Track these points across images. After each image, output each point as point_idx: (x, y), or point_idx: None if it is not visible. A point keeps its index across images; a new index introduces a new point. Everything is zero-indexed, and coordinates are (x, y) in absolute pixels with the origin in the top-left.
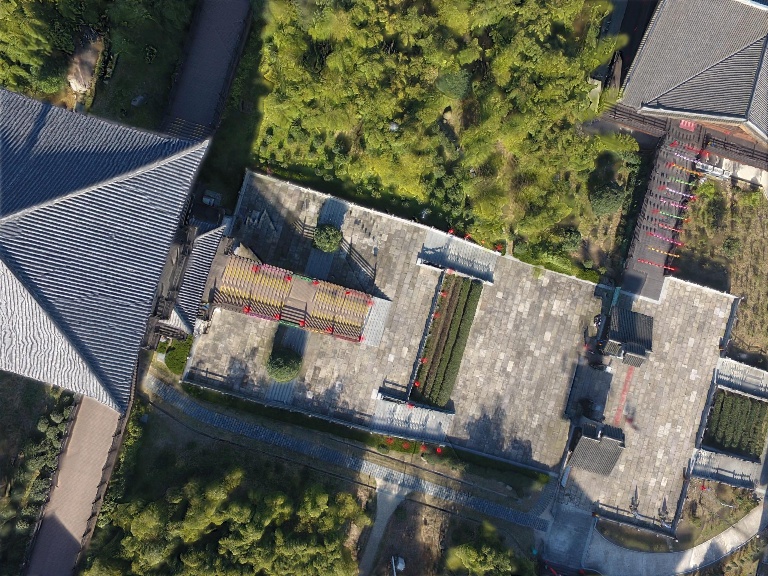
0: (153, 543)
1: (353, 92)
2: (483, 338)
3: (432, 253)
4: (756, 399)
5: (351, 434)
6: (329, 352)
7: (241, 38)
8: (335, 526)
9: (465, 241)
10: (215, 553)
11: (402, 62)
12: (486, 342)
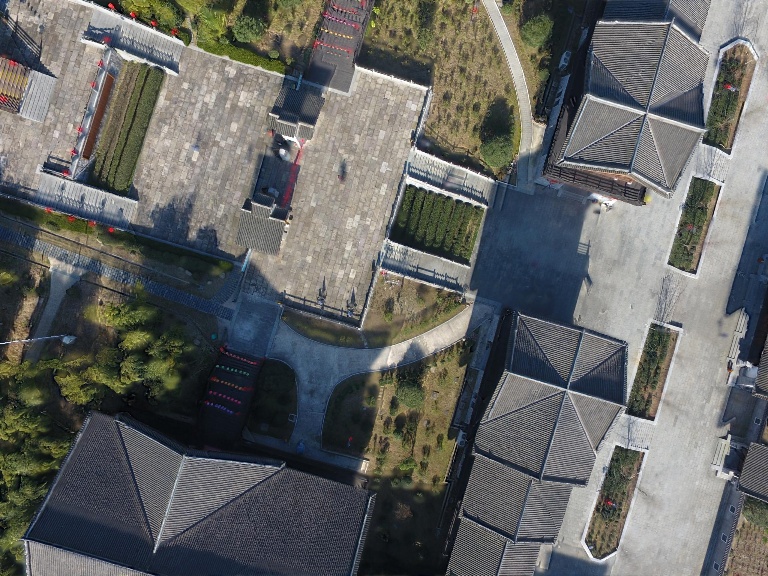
0: None
1: None
2: (168, 128)
3: (100, 33)
4: (462, 201)
5: (18, 209)
6: None
7: None
8: None
9: (138, 24)
10: None
11: None
12: (171, 132)
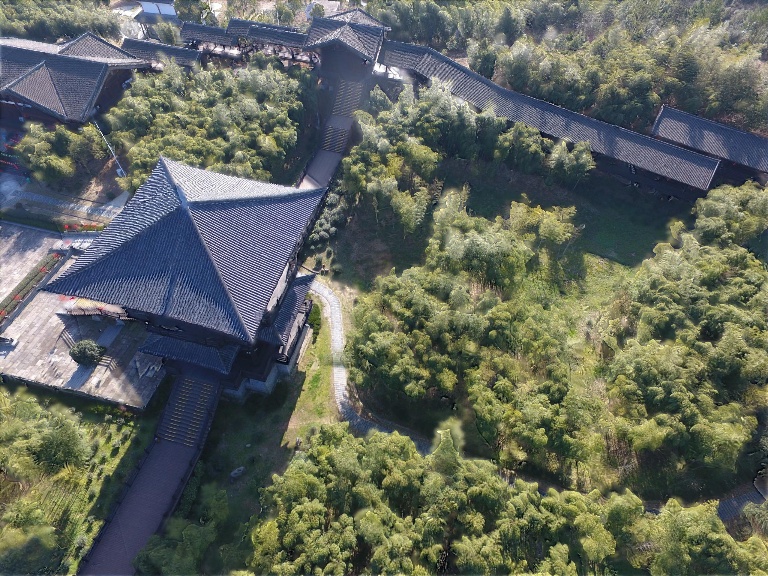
0: (240, 160)
1: None
2: None
3: (1, 353)
4: None
5: None
6: None
7: (98, 541)
8: None
9: None
10: (207, 158)
11: None
12: None
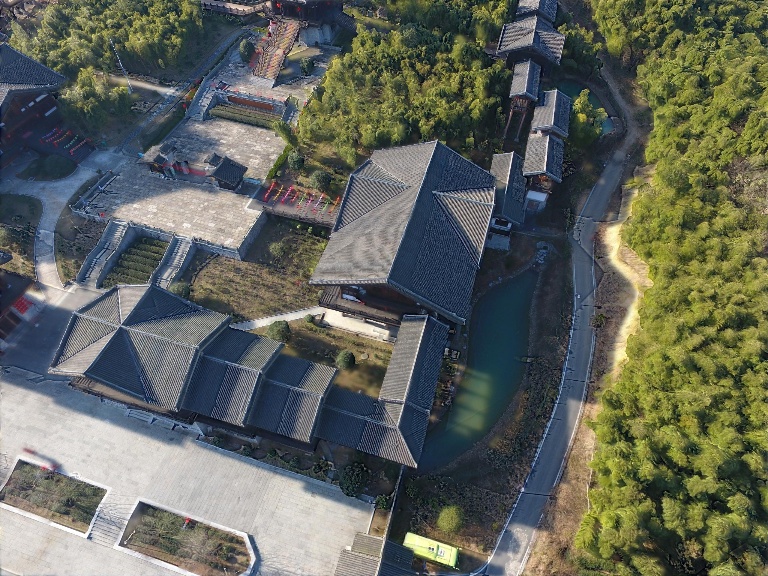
0: None
1: (369, 50)
2: (244, 132)
3: (295, 103)
4: None
5: None
6: (251, 70)
7: None
8: (164, 44)
9: None
10: None
11: (387, 69)
12: (241, 133)
